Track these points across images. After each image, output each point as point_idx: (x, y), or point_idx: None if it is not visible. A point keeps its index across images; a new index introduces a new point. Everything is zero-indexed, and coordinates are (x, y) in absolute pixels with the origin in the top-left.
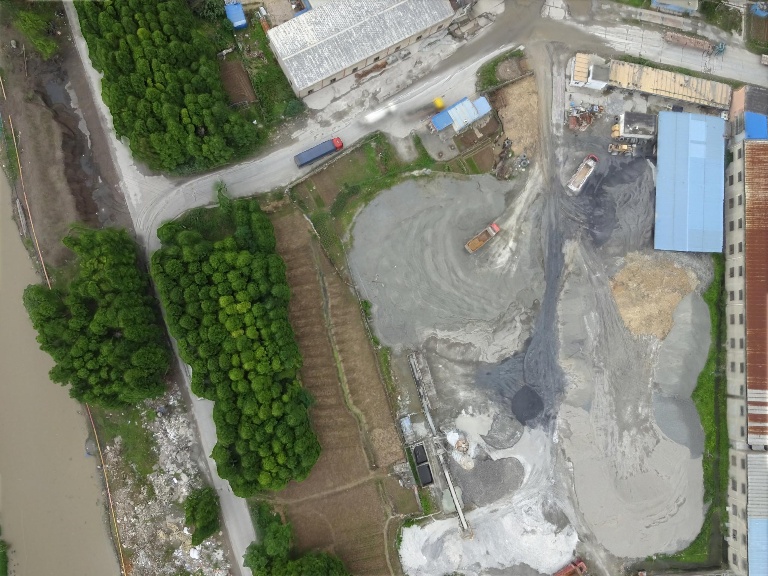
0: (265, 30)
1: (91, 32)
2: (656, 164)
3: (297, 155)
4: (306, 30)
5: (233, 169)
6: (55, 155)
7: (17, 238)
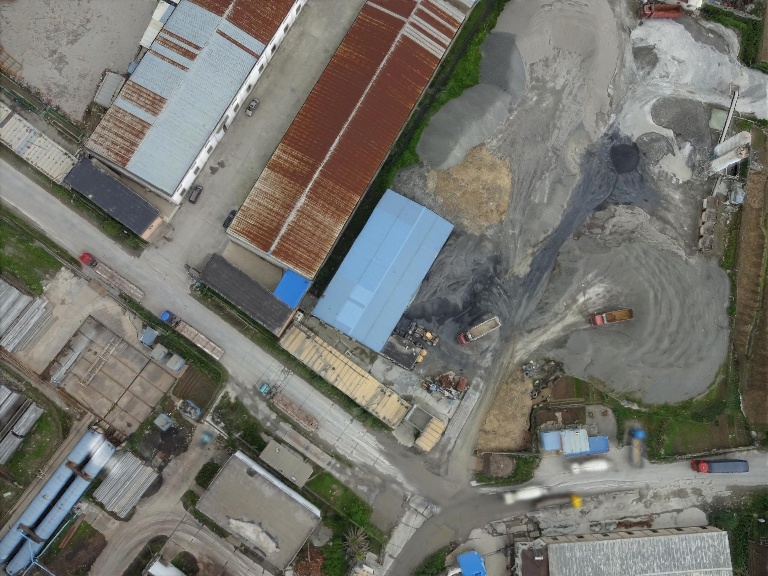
0: None
1: None
2: None
3: None
4: None
5: None
6: None
7: None
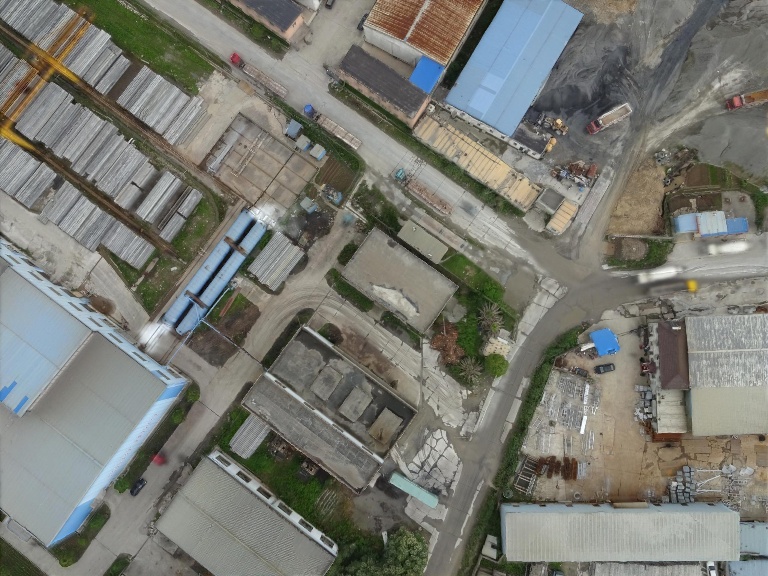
0: None
1: None
2: None
3: None
4: None
5: None
6: None
7: None
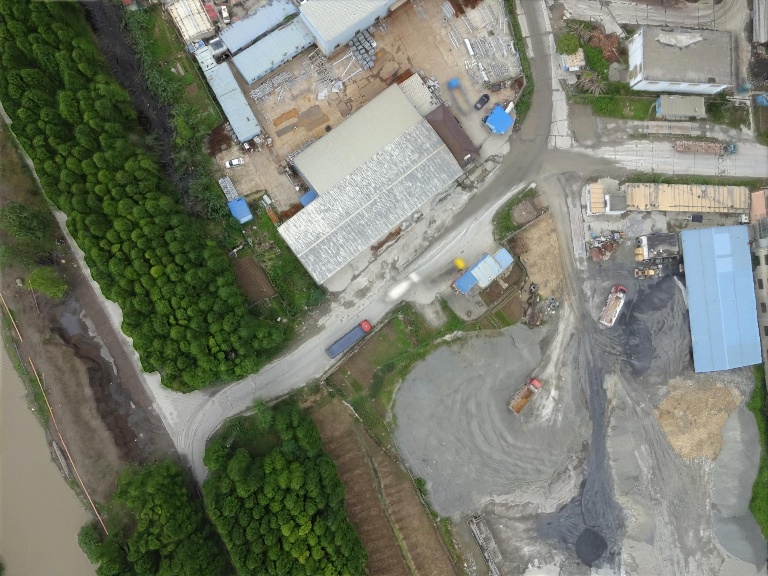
0: (273, 220)
1: (102, 277)
2: (685, 286)
3: (328, 349)
4: (317, 220)
5: (264, 369)
6: (84, 393)
7: (60, 478)
